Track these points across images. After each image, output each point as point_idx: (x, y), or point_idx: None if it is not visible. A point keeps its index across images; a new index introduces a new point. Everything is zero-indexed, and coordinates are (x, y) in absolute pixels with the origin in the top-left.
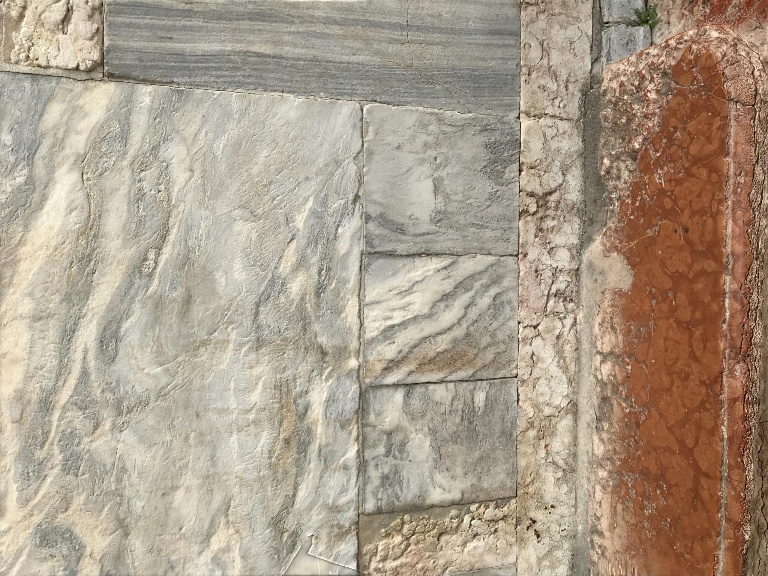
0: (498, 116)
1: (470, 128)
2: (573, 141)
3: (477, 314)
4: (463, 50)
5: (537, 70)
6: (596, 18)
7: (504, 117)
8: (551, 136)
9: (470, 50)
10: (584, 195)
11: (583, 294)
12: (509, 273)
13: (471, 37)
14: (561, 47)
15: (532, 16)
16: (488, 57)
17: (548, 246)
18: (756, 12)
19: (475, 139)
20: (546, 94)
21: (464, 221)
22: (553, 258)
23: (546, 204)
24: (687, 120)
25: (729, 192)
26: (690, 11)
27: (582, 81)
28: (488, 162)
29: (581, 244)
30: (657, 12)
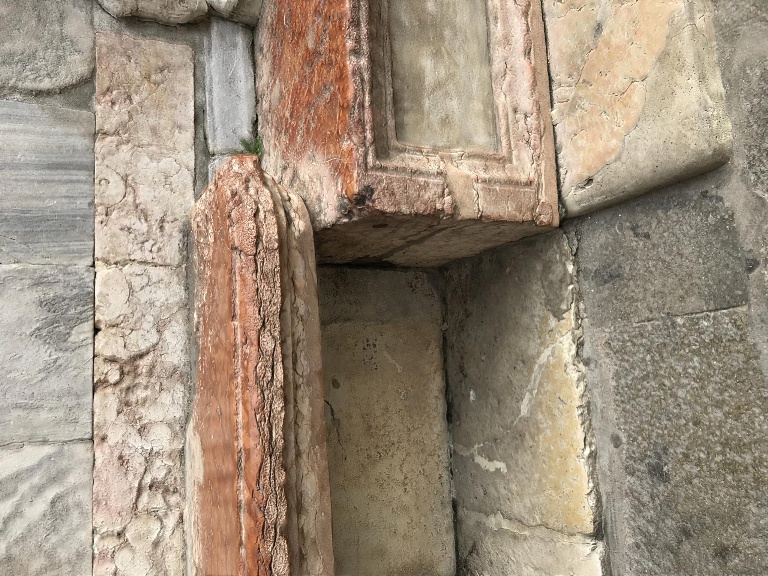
0: (60, 265)
1: (15, 282)
2: (172, 290)
3: (24, 524)
4: (8, 188)
5: (119, 209)
6: (200, 150)
7: (69, 266)
8: (140, 286)
9: (19, 188)
10: (189, 355)
11: (186, 481)
12: (77, 463)
13: (20, 173)
14: (152, 183)
15: (110, 148)
16: (46, 196)
17: (138, 422)
18: (311, 143)
19: (23, 295)
20: (132, 237)
21: (2, 401)
22: (145, 437)
23: (136, 369)
24: (217, 271)
25: (238, 365)
26: (279, 142)
27: (183, 220)
28: (43, 323)
29: (187, 416)
30: (263, 143)
